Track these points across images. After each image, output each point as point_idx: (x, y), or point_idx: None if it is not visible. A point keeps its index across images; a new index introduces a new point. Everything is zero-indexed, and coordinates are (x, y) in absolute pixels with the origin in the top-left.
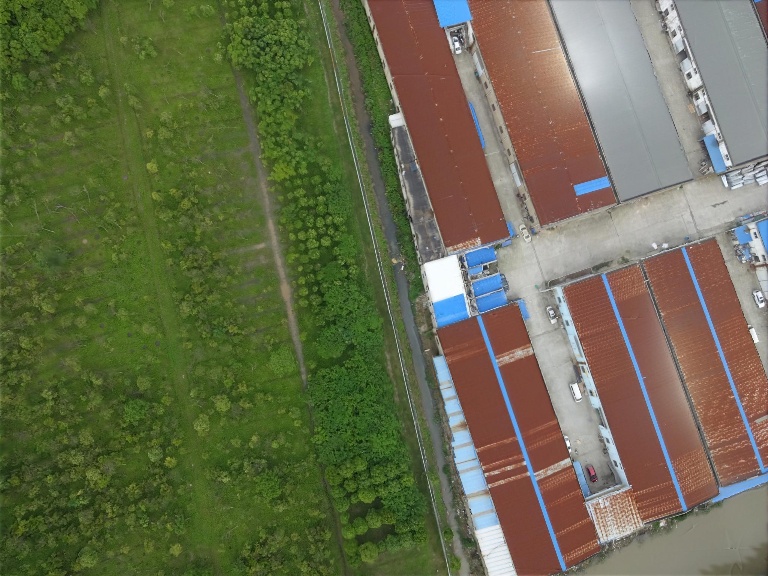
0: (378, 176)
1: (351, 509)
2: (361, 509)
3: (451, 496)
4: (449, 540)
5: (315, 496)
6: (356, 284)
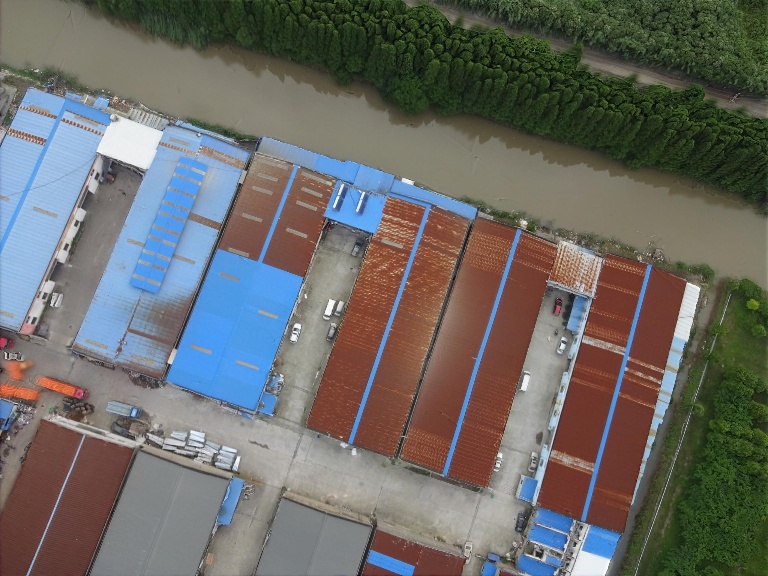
0: None
1: None
2: (766, 428)
3: (678, 376)
4: (706, 347)
5: None
6: None
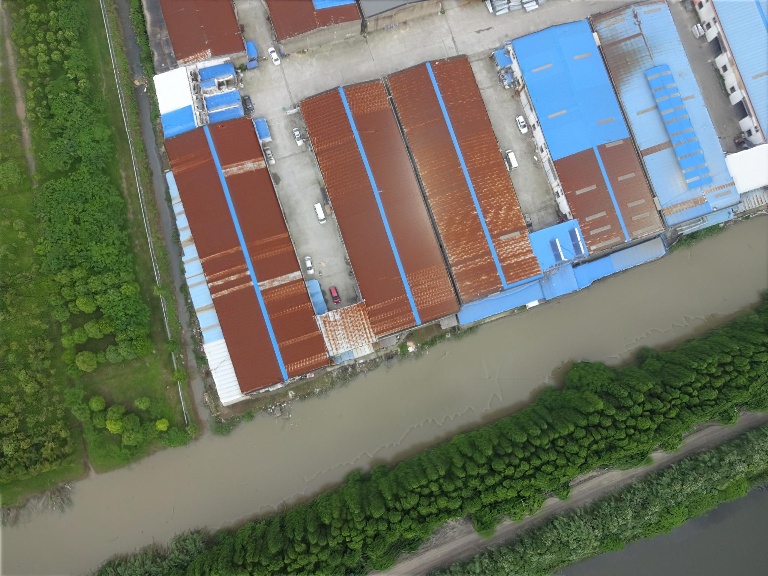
0: None
1: (73, 320)
2: (83, 320)
3: (188, 316)
4: (181, 357)
5: (37, 307)
6: (84, 97)
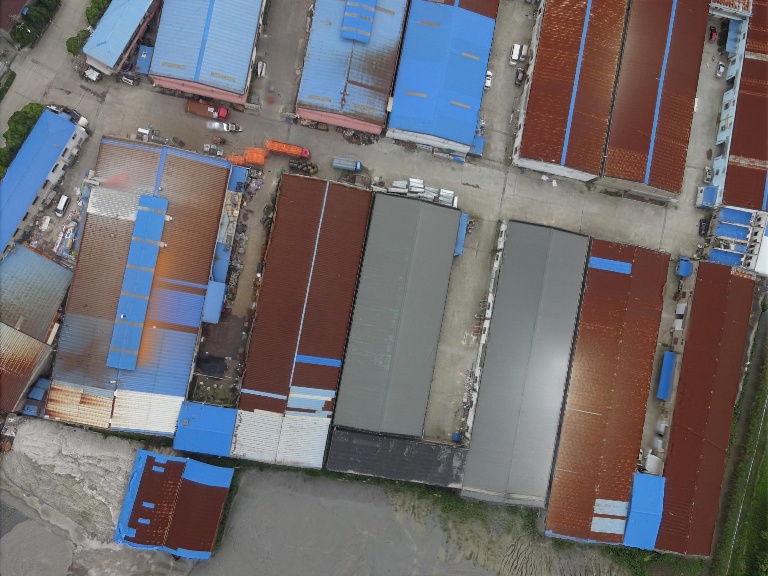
0: (751, 373)
1: None
2: None
3: None
4: None
5: None
6: None
